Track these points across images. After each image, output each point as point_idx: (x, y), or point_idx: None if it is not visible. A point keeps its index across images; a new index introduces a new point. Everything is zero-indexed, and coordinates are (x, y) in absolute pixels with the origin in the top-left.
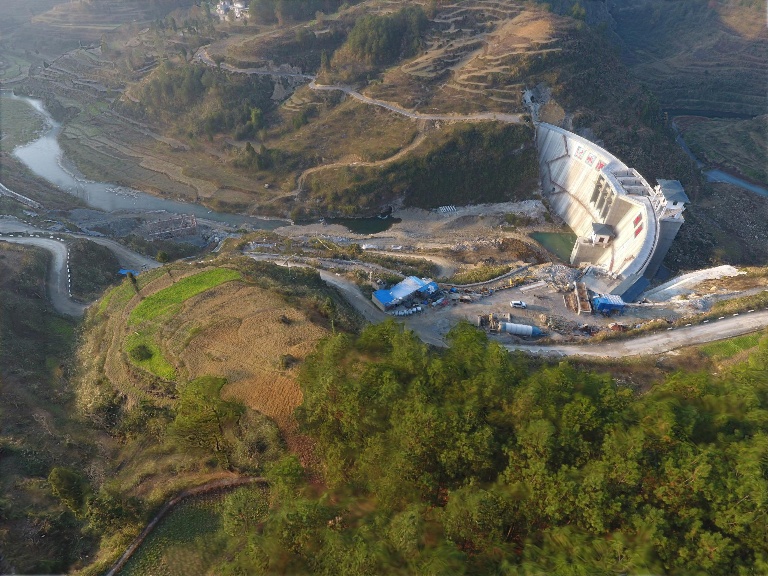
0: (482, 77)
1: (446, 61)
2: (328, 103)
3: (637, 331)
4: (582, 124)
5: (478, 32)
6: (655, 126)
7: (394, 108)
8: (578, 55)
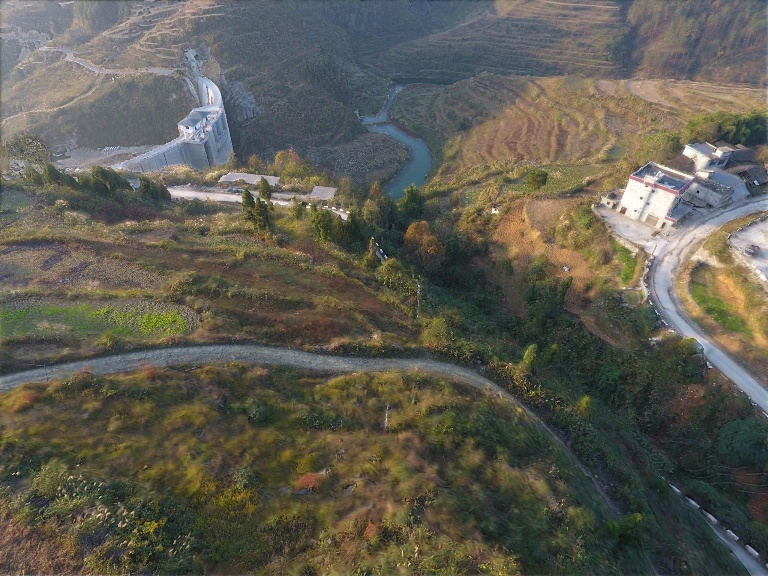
0: (154, 38)
1: (142, 26)
2: (47, 62)
3: None
4: (234, 78)
5: (176, 1)
6: (322, 84)
7: (87, 65)
8: (240, 20)
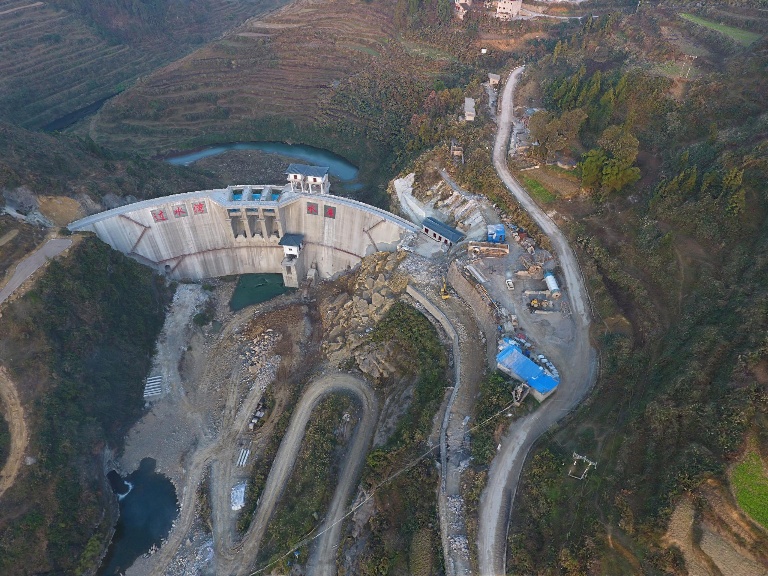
0: None
1: None
2: None
3: (535, 224)
4: (100, 195)
5: None
6: None
7: None
8: None
